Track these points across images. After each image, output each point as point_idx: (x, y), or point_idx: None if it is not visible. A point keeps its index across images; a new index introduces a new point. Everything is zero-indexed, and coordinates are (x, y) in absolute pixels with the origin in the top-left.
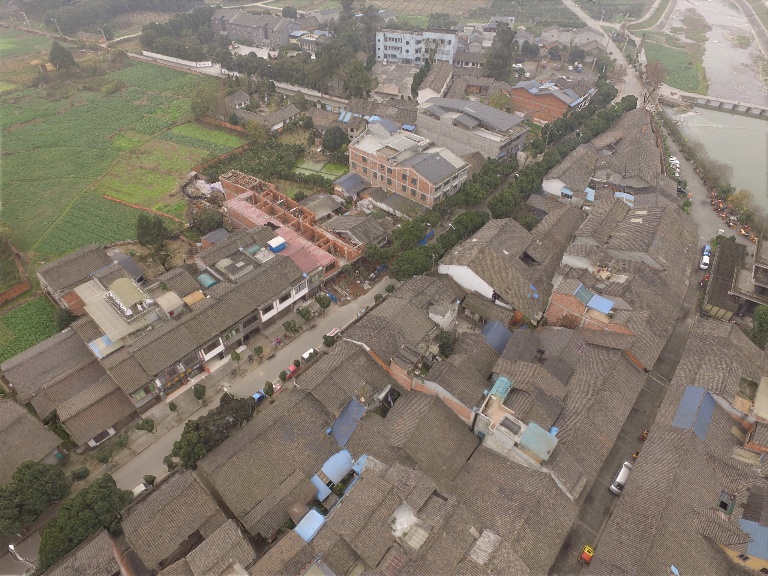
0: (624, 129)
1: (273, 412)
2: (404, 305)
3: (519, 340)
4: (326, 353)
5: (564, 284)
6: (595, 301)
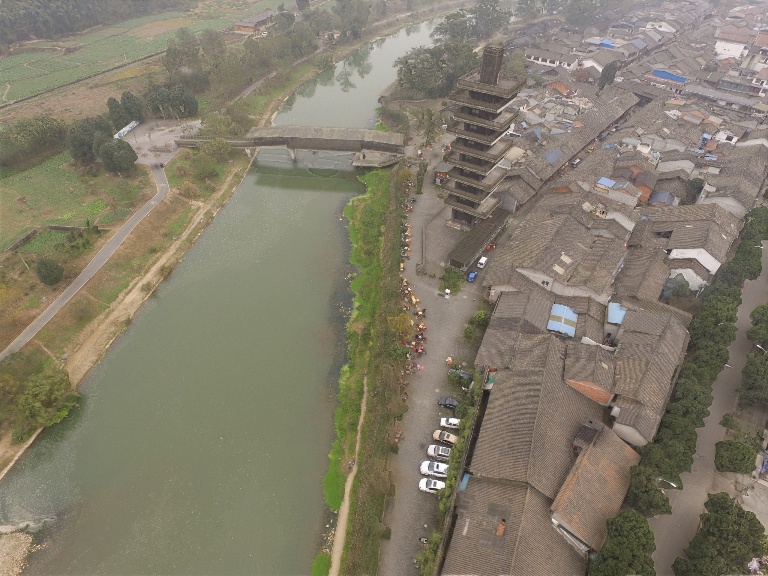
0: (539, 575)
1: (761, 161)
2: (740, 182)
3: (650, 181)
4: (763, 175)
5: (635, 192)
6: (611, 183)
